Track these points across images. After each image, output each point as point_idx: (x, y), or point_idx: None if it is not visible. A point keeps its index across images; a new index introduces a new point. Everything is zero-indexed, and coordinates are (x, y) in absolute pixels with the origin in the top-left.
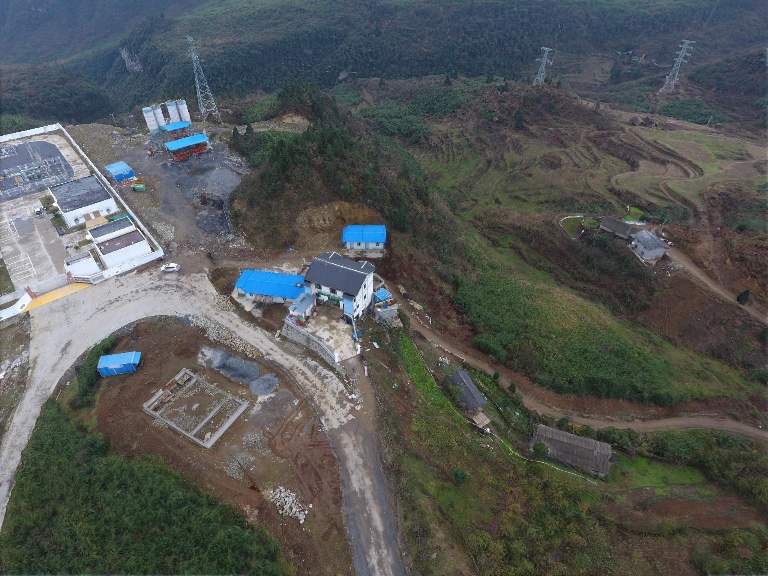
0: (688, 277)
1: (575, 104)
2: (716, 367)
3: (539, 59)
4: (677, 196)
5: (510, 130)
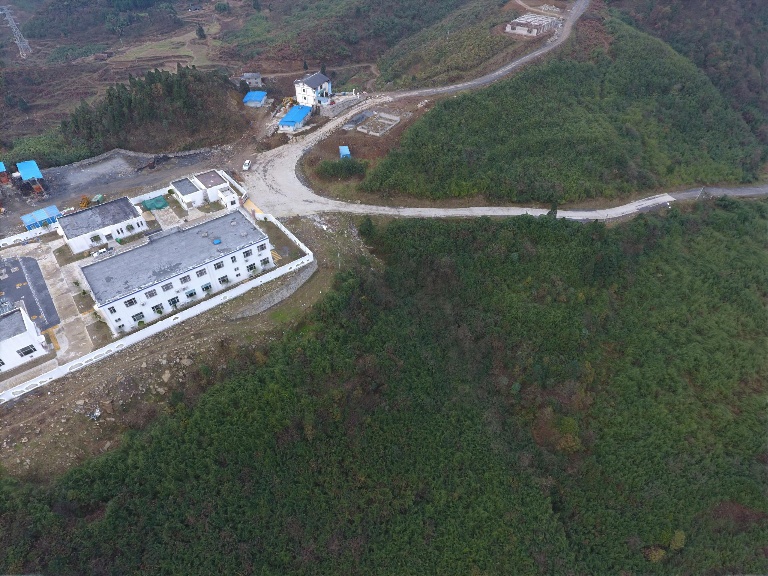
0: (282, 77)
1: (45, 68)
2: None
3: None
4: (208, 67)
5: (21, 116)
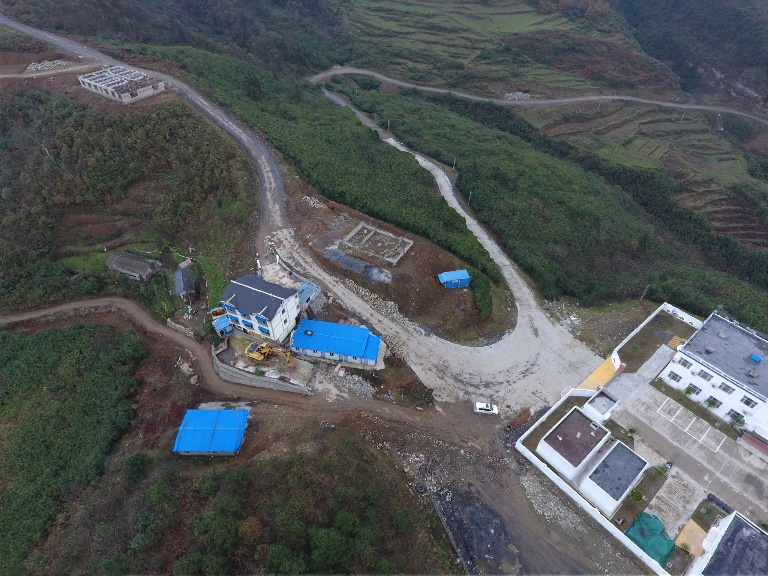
0: None
1: None
2: None
3: None
4: None
5: None
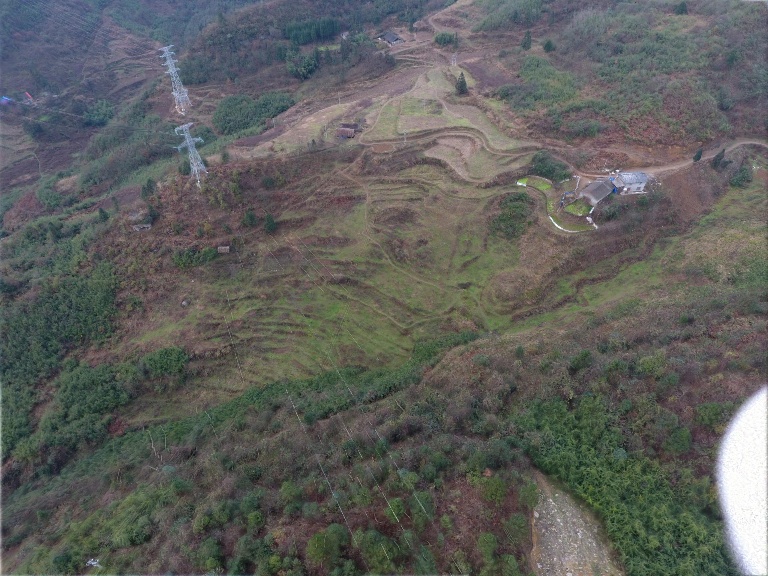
0: (666, 175)
1: (286, 160)
2: (735, 197)
3: (182, 145)
4: (519, 150)
5: (266, 241)
